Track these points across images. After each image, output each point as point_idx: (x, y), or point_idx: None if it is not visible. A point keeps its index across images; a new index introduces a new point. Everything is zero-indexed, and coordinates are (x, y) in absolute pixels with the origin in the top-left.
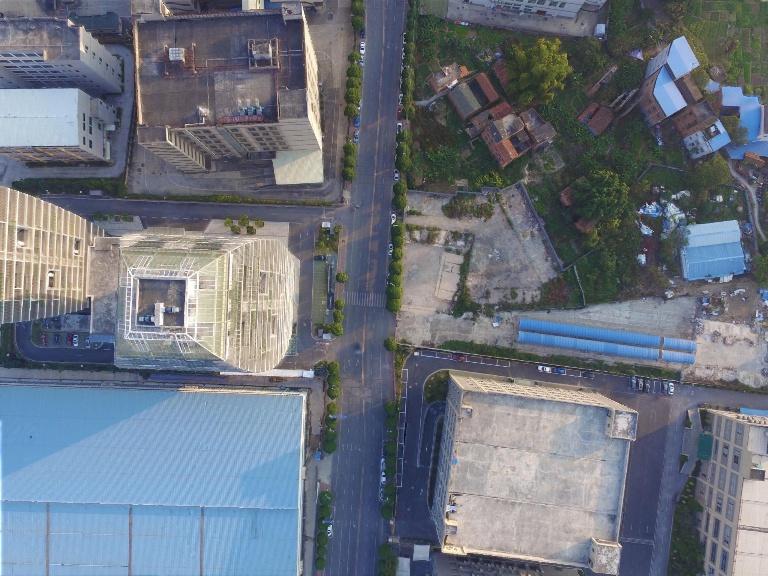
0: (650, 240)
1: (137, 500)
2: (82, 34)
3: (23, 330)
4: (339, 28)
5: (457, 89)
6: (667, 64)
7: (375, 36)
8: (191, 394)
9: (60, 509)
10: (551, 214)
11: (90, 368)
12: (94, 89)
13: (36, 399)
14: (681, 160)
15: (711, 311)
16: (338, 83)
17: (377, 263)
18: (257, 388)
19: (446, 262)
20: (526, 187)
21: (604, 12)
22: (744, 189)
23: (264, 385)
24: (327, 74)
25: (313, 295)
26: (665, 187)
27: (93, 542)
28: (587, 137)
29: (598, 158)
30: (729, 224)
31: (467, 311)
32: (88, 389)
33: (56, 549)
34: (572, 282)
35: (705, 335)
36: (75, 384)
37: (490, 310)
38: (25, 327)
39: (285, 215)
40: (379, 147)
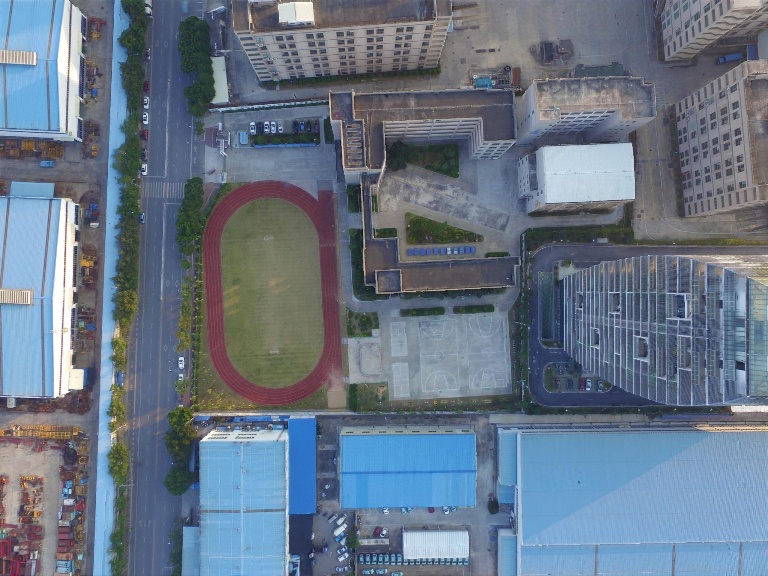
0: None
1: (686, 538)
2: None
3: (535, 377)
4: None
5: None
6: None
7: None
8: (724, 434)
9: (608, 550)
10: None
11: (615, 412)
12: (600, 139)
13: (579, 445)
14: None
15: None
16: None
17: None
18: (759, 423)
19: None
20: None
21: None
22: None
23: (763, 420)
24: None
25: None
26: None
27: None
28: None
29: None
30: None
31: None
32: (627, 433)
33: None
34: None
35: None
36: (593, 427)
37: None
38: (537, 374)
39: None
40: None
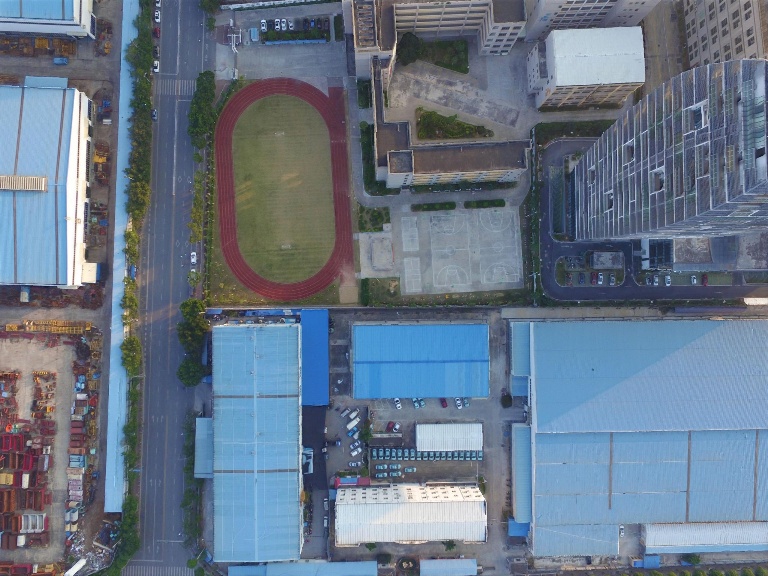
0: None
1: (701, 426)
2: None
3: (547, 271)
4: None
5: None
6: None
7: None
8: (738, 322)
9: (623, 439)
10: None
11: (628, 303)
12: None
13: (592, 333)
14: None
15: None
16: None
17: None
18: None
19: None
20: None
21: None
22: None
23: None
24: None
25: None
26: None
27: (653, 470)
28: None
29: None
30: None
31: None
32: (641, 321)
33: (619, 478)
34: None
35: None
36: (606, 320)
37: None
38: (549, 268)
39: None
40: None
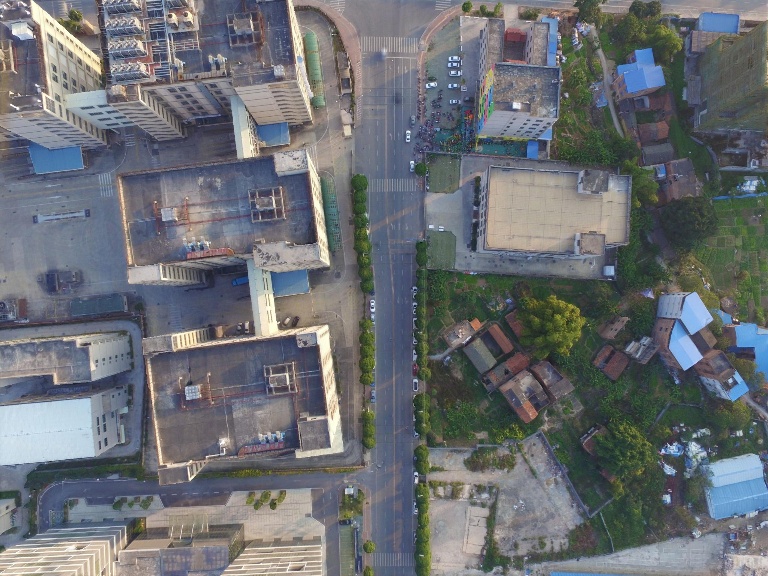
0: (674, 480)
1: None
2: (91, 352)
3: None
4: (347, 286)
5: (471, 347)
6: (681, 320)
7: (384, 292)
8: None
9: None
10: (573, 460)
11: None
12: None
13: None
14: (699, 396)
15: (739, 547)
16: (350, 342)
17: (403, 522)
18: None
19: (472, 516)
20: (546, 434)
21: (611, 249)
22: (763, 421)
23: None
24: (339, 334)
25: (341, 559)
26: (685, 424)
27: None
28: (604, 382)
29: (616, 400)
30: (751, 461)
31: (497, 565)
32: None
33: None
34: (599, 528)
35: (735, 570)
36: None
37: (520, 563)
38: None
39: (306, 481)
40: (396, 404)
